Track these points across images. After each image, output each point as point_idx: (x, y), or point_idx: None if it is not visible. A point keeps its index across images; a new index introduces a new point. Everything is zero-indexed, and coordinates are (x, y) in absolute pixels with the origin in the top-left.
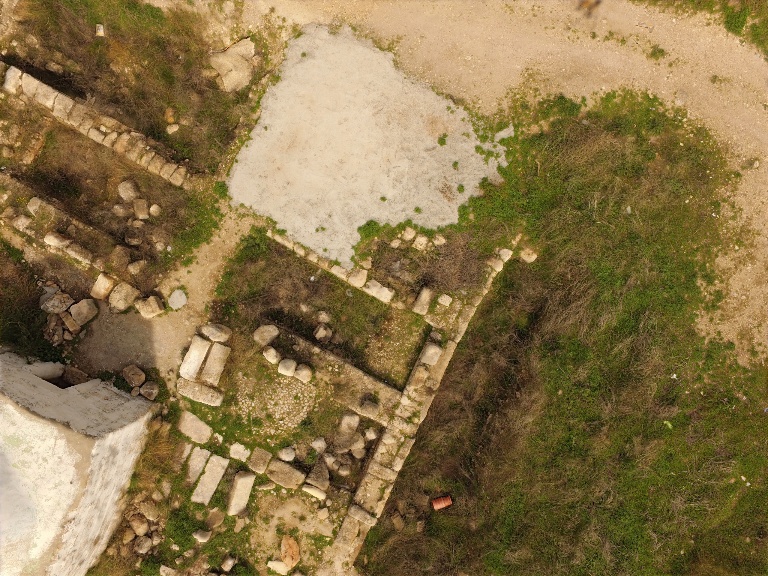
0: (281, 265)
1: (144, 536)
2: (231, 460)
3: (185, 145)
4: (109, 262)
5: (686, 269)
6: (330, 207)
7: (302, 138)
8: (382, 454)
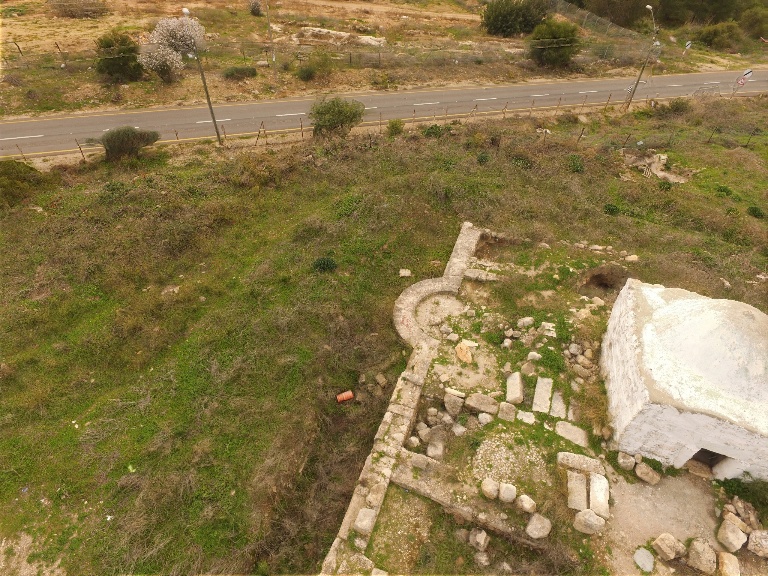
0: None
1: (577, 355)
2: (531, 410)
3: None
4: None
5: None
6: None
7: None
8: (403, 424)
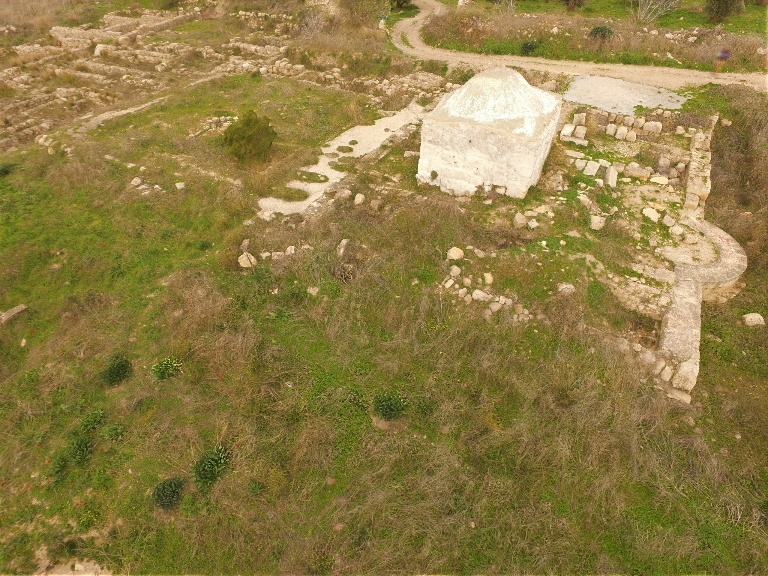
0: None
1: None
2: (600, 165)
3: None
4: None
5: None
6: None
7: (592, 90)
8: None
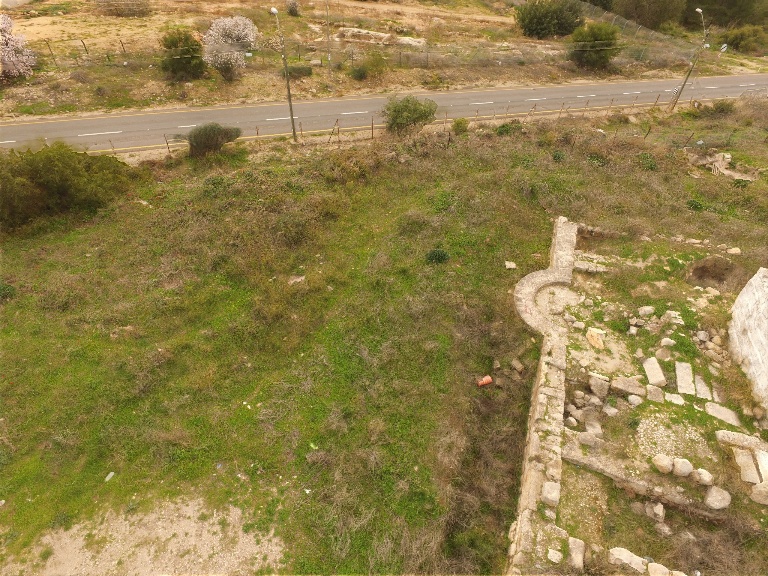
0: None
1: (706, 341)
2: (677, 393)
3: None
4: None
5: None
6: None
7: None
8: (559, 406)
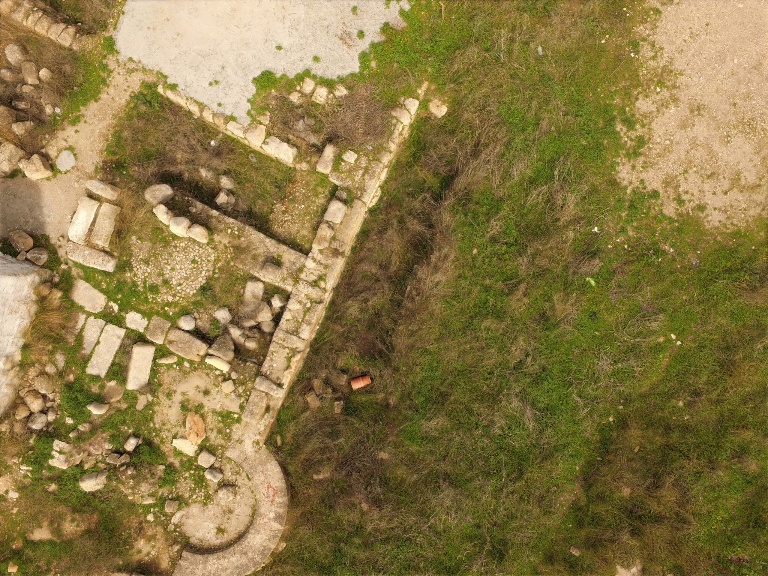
0: (173, 121)
1: (39, 412)
2: (128, 330)
3: (79, 12)
4: None
5: (604, 113)
6: (223, 58)
7: None
8: (287, 321)
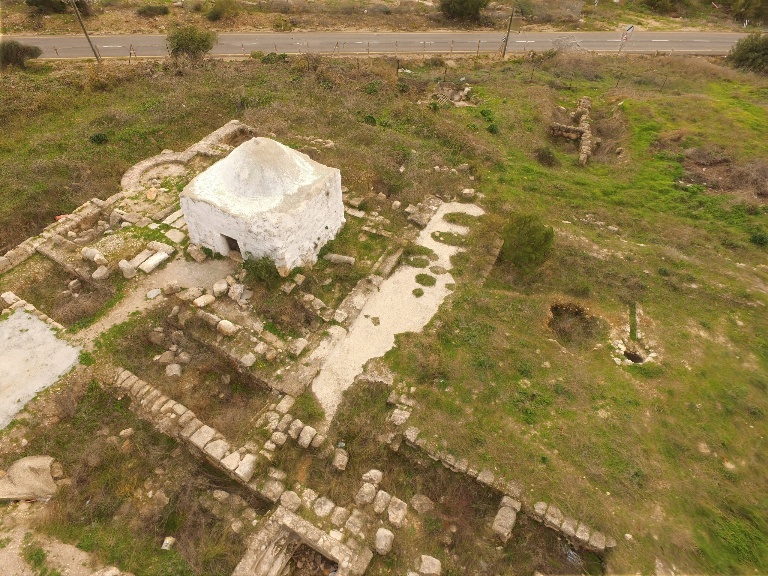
0: None
1: None
2: (161, 223)
3: None
4: (192, 314)
5: None
6: (5, 343)
7: None
8: None
